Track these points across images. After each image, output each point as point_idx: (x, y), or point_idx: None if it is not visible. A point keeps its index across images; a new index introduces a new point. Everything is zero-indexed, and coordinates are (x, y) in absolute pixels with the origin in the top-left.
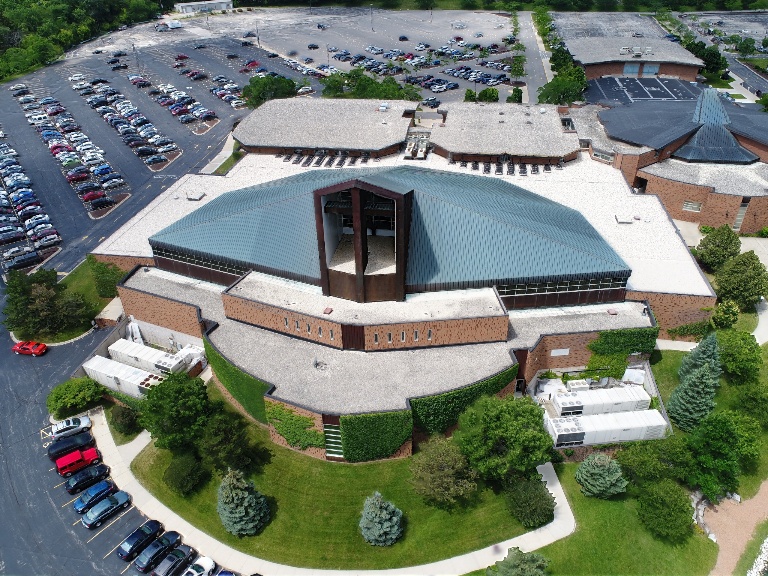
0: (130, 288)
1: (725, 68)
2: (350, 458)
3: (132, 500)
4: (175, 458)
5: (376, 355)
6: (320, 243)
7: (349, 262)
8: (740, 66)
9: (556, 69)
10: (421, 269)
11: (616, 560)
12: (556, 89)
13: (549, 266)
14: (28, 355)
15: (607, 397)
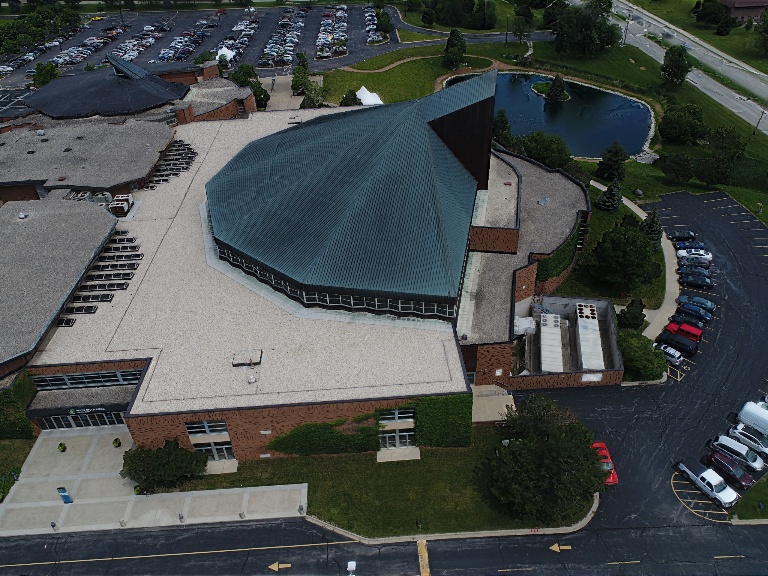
0: (513, 327)
1: None
2: None
3: None
4: None
5: None
6: None
7: None
8: None
9: None
10: None
11: None
12: None
13: None
14: None
15: None
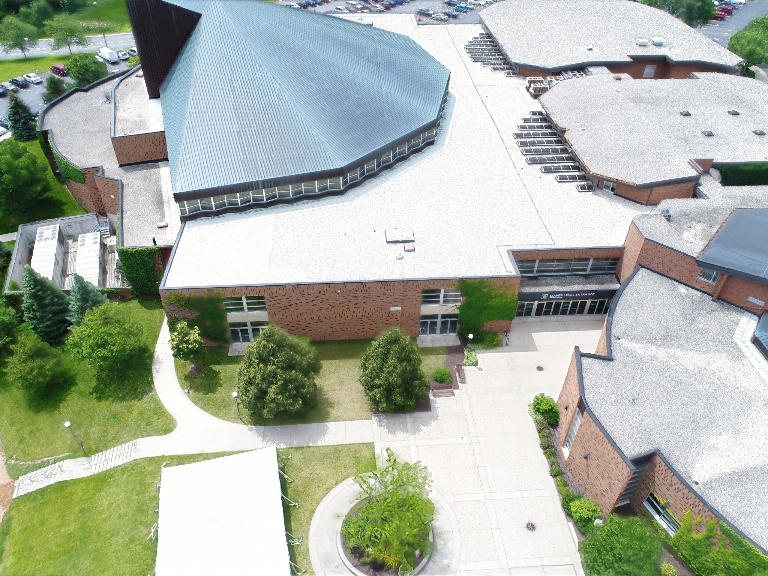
0: None
1: None
2: None
3: None
4: None
5: None
6: None
7: None
8: None
9: None
10: (166, 82)
11: None
12: None
13: None
14: None
15: (85, 261)
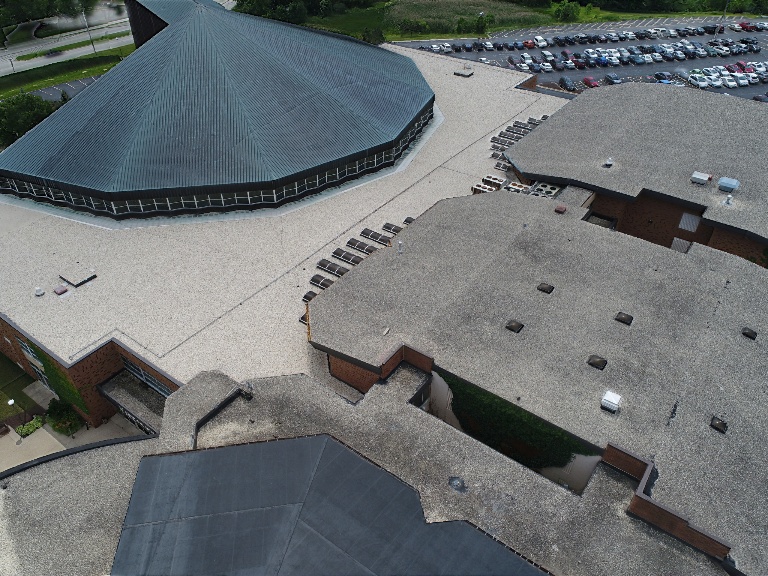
0: None
1: None
2: None
3: None
4: None
5: None
6: None
7: None
8: None
9: None
10: None
11: None
12: None
13: None
14: None
15: None
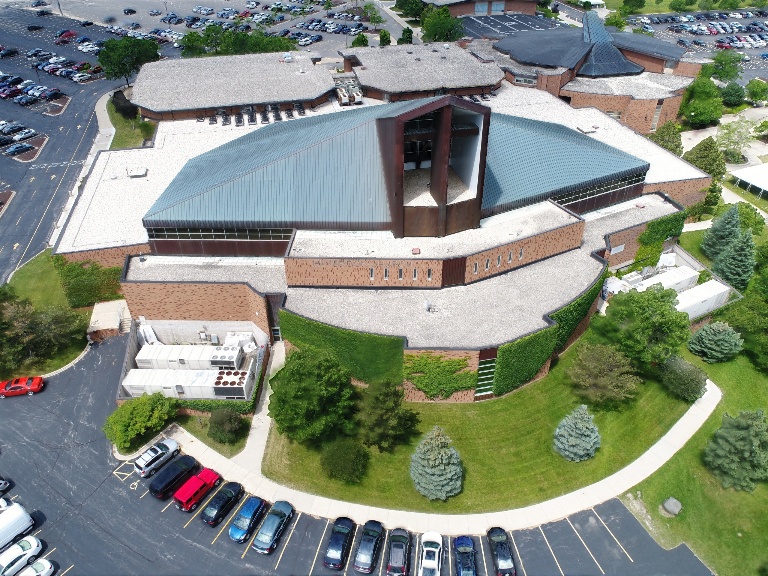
0: (142, 281)
1: (549, 4)
2: (500, 391)
3: (294, 507)
4: (322, 446)
5: (476, 286)
6: (398, 178)
7: (419, 196)
8: (554, 2)
9: (410, 14)
10: (486, 192)
11: (766, 406)
12: (442, 27)
13: (589, 171)
14: (20, 396)
15: (667, 280)
